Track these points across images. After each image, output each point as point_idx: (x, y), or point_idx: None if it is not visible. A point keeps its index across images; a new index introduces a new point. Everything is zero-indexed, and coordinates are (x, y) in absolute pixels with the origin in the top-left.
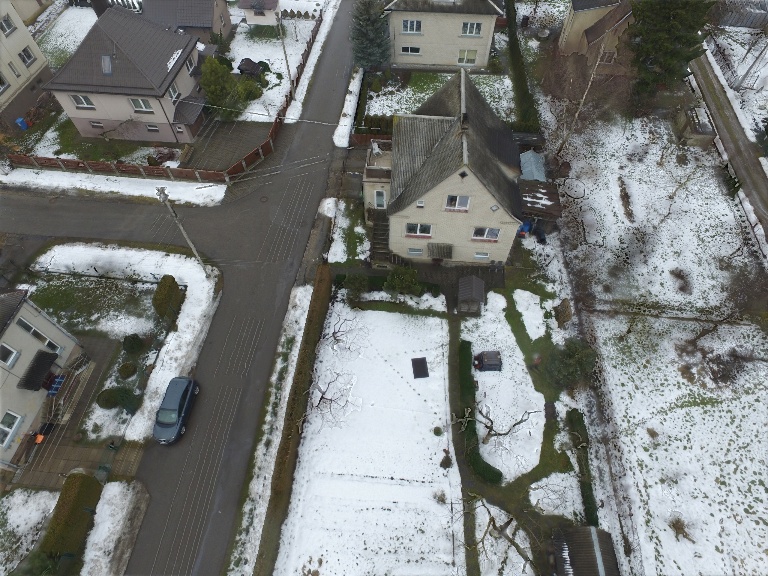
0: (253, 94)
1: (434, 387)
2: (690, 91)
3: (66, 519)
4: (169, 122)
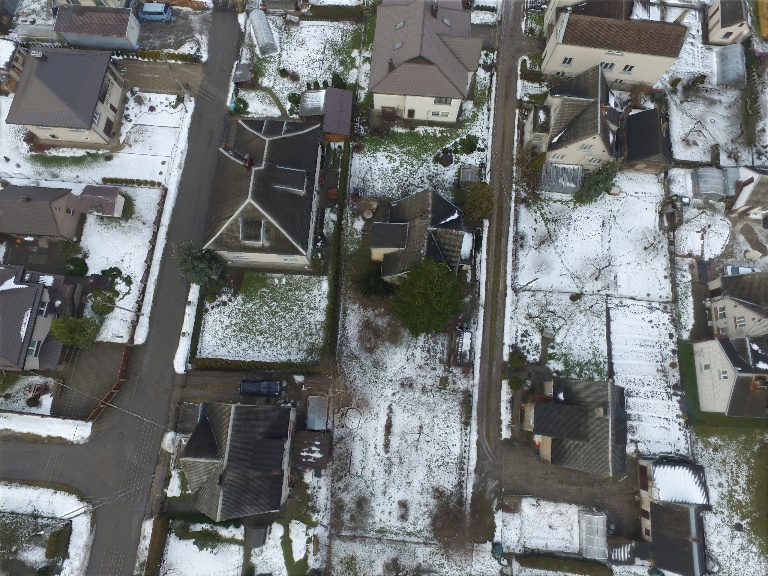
0: (106, 312)
1: None
2: (477, 295)
3: None
4: (36, 369)
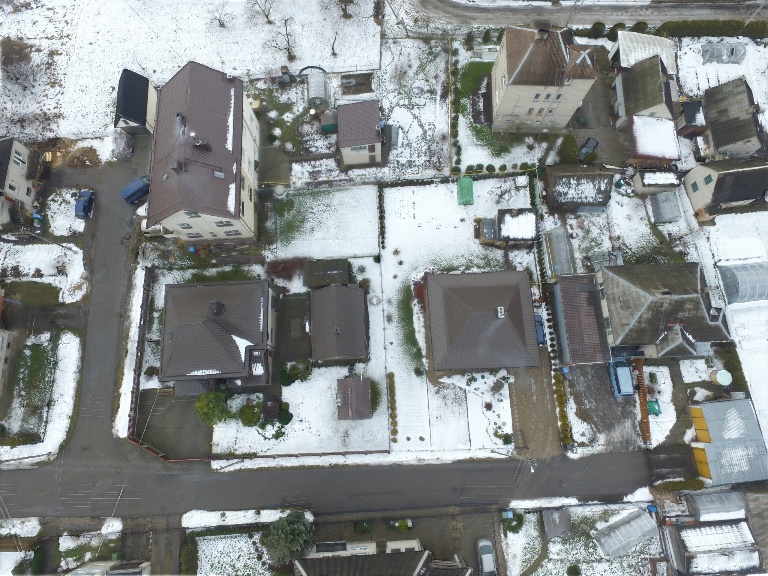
0: (242, 422)
1: None
2: None
3: None
4: None
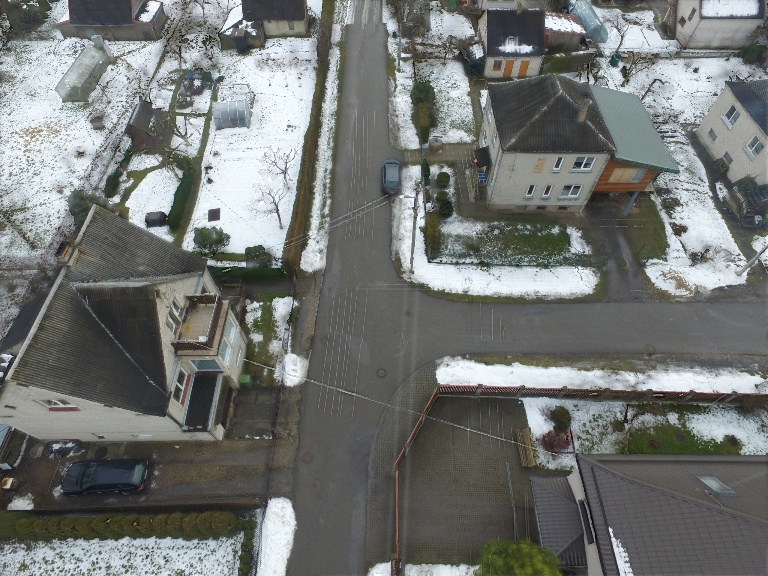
0: None
1: (206, 204)
2: None
3: None
4: None
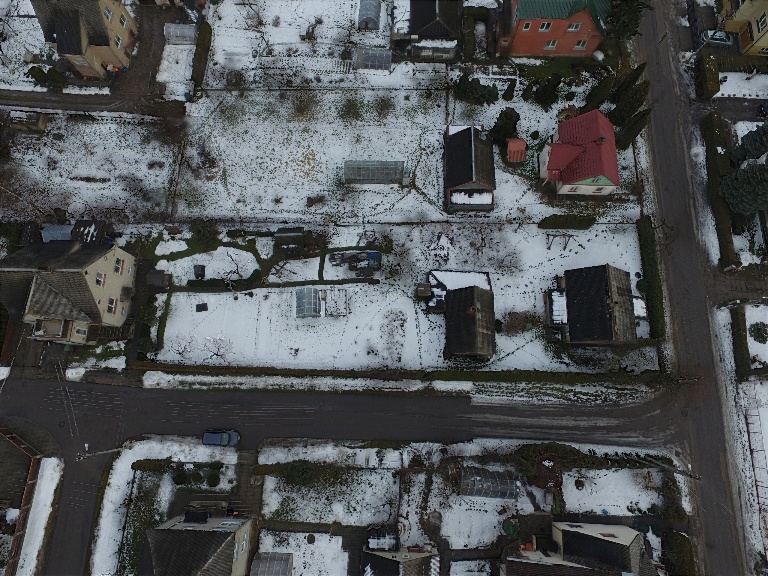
0: None
1: (213, 300)
2: None
3: (273, 467)
4: None
